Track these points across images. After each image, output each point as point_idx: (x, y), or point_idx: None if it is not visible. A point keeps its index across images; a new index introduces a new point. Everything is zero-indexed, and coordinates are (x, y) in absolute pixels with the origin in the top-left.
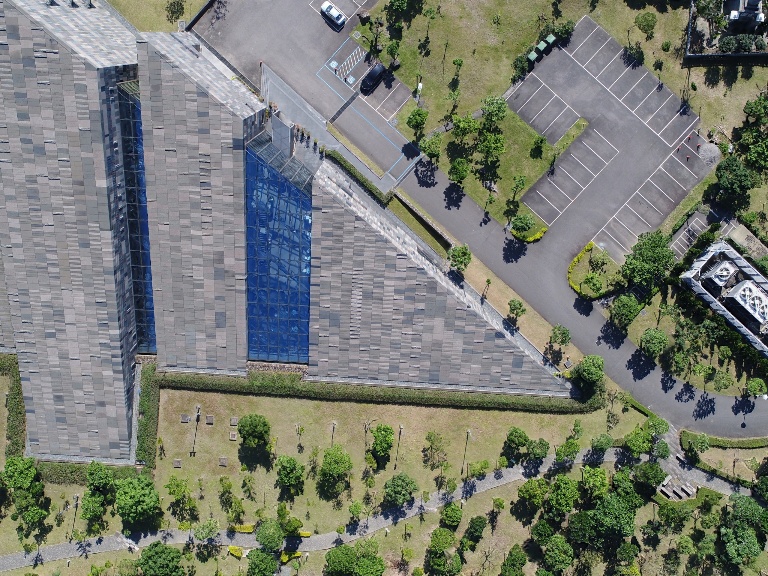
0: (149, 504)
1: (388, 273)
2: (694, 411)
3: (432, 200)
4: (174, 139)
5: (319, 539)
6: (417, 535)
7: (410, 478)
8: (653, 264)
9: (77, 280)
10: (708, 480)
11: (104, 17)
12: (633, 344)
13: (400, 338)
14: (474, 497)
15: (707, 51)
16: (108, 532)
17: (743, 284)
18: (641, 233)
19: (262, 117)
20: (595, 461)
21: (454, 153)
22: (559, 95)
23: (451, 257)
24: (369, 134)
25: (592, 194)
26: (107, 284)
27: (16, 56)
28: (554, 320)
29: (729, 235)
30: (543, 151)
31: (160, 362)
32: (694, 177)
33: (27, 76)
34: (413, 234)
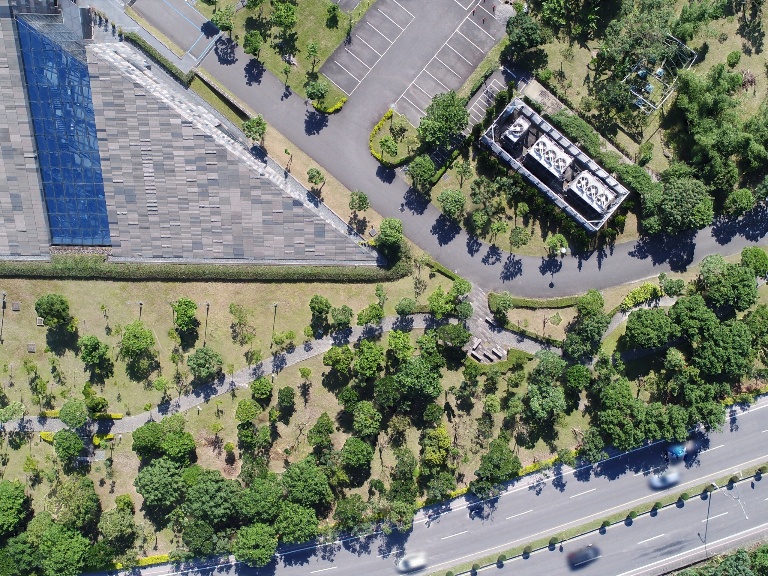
0: None
1: (176, 143)
2: (501, 273)
3: (233, 77)
4: None
5: (131, 420)
6: (230, 412)
7: (214, 351)
8: (445, 122)
9: None
10: (518, 342)
11: None
12: (437, 209)
13: (198, 212)
14: (285, 370)
15: None
16: None
17: (538, 139)
18: (435, 94)
19: None
20: (404, 328)
21: (253, 29)
22: None
23: (246, 128)
24: (168, 15)
25: (390, 61)
26: None
27: None
28: (357, 189)
29: None
30: (339, 20)
31: None
32: (491, 39)
33: None
34: (217, 113)
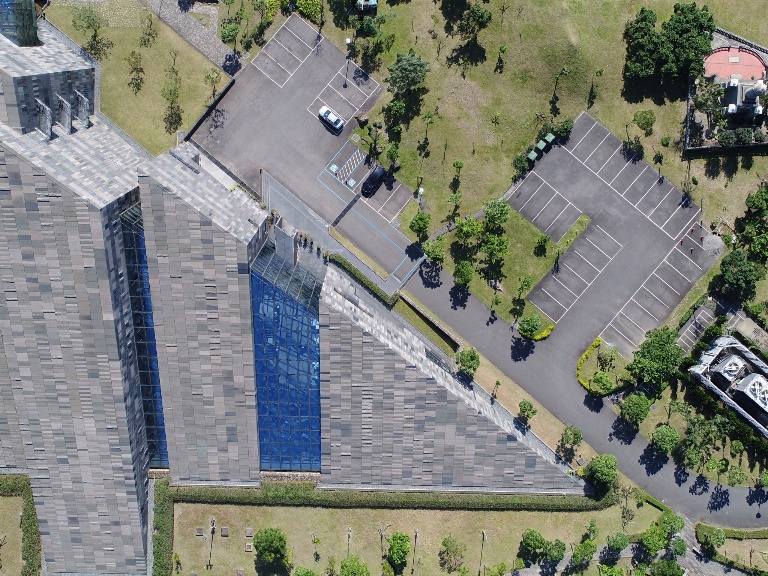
0: None
1: (398, 384)
2: (708, 503)
3: (438, 301)
4: (179, 266)
5: None
6: None
7: None
8: (662, 362)
9: (87, 408)
10: (725, 572)
11: (103, 134)
12: (645, 439)
13: (412, 445)
14: None
15: (706, 143)
16: None
17: (752, 378)
18: (648, 330)
19: (265, 227)
20: (612, 557)
21: (458, 253)
22: (560, 192)
23: (460, 361)
24: (372, 236)
25: (597, 290)
26: (118, 411)
27: (19, 201)
28: (565, 418)
29: (736, 328)
30: (547, 249)
31: (173, 476)
32: (699, 269)
33: (30, 219)
34: (420, 334)
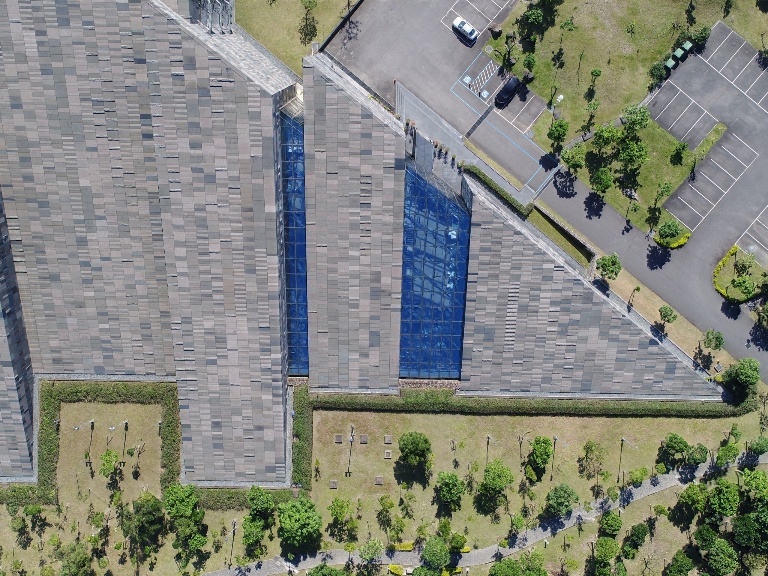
0: (314, 527)
1: (545, 285)
2: None
3: (572, 210)
4: (336, 161)
5: (479, 554)
6: (576, 545)
7: (571, 489)
8: None
9: (241, 306)
10: None
11: (243, 42)
12: None
13: (554, 349)
14: (631, 505)
15: None
16: (267, 556)
17: None
18: None
19: None
20: (750, 463)
21: (592, 163)
22: (696, 101)
23: (601, 267)
24: (506, 147)
25: (734, 198)
26: (271, 309)
27: (191, 86)
28: (702, 325)
29: None
30: (683, 157)
31: (312, 384)
32: None
33: (201, 106)
34: (554, 245)
